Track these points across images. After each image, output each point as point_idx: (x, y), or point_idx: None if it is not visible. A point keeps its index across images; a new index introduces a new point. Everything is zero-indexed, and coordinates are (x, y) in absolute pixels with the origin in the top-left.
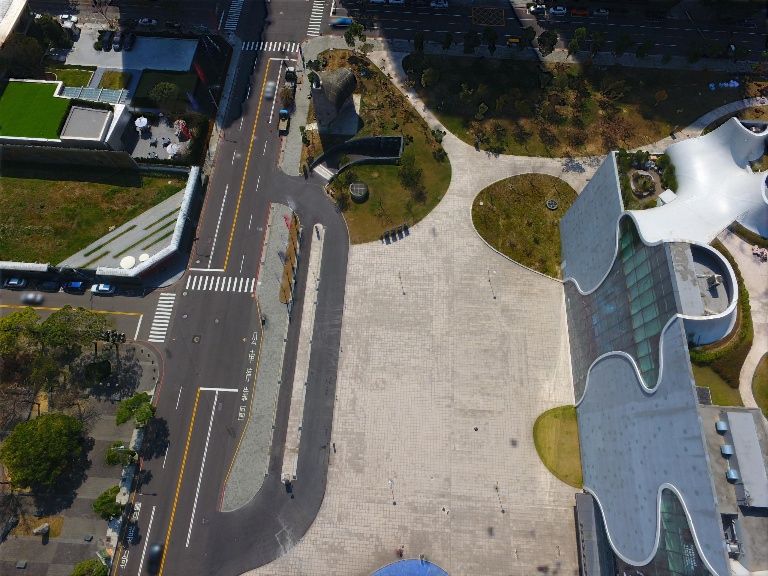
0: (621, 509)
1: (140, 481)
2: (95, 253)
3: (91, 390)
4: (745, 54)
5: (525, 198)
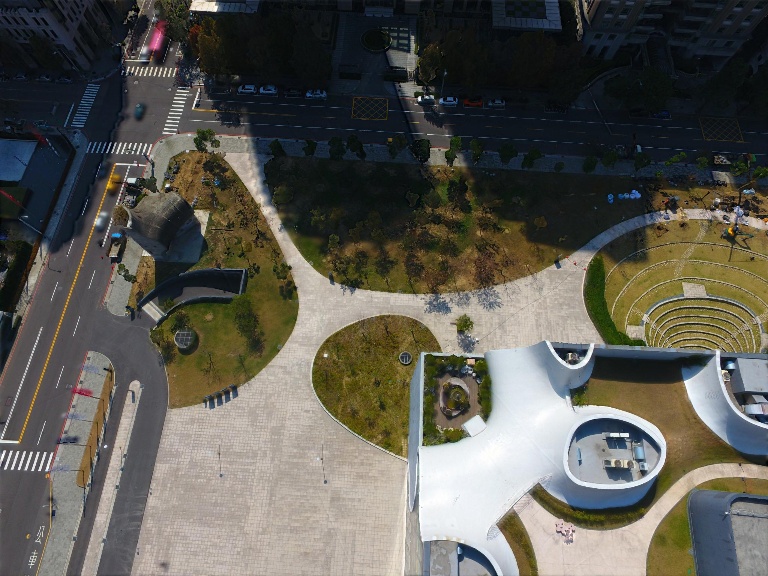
0: None
1: None
2: None
3: None
4: (645, 164)
5: (376, 348)
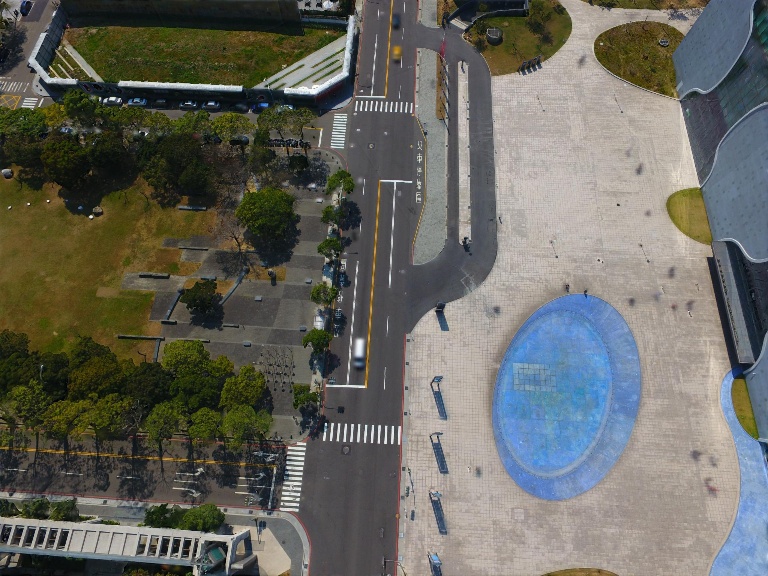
0: (763, 225)
1: (342, 244)
2: (273, 85)
3: (290, 181)
4: None
5: (639, 39)
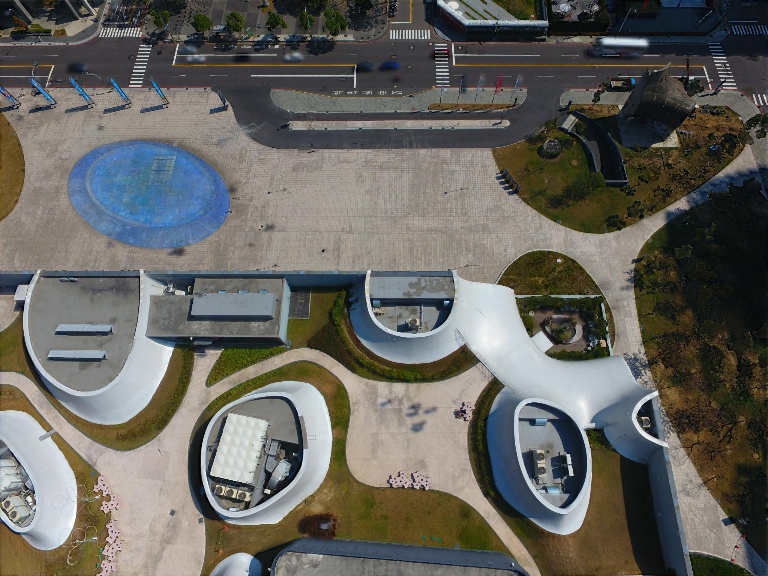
0: None
1: (293, 45)
2: None
3: None
4: None
5: None
